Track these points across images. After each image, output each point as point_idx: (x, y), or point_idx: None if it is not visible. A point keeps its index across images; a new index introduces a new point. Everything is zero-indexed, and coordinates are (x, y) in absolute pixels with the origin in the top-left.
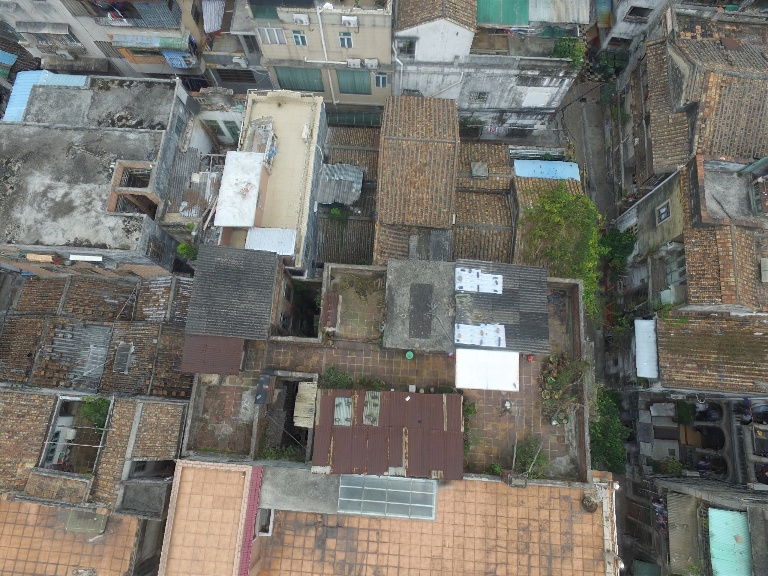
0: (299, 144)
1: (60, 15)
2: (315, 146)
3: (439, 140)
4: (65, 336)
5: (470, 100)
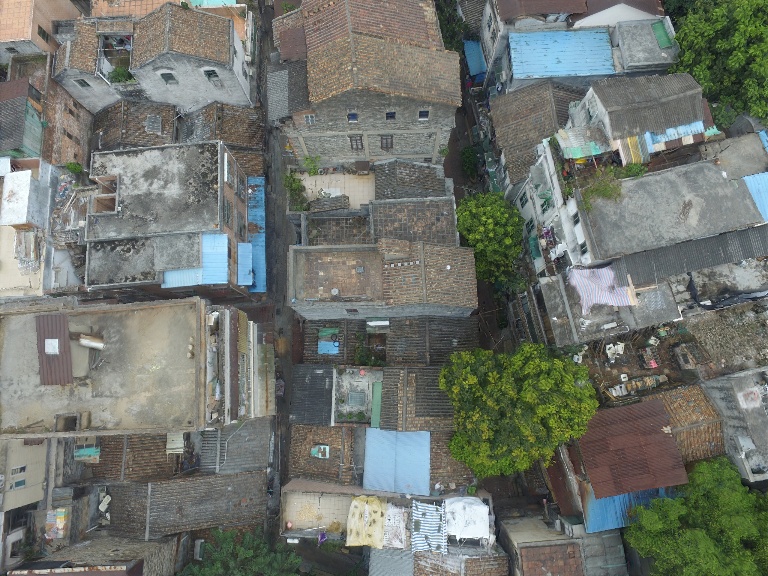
0: (5, 260)
1: None
2: None
3: None
4: None
5: None
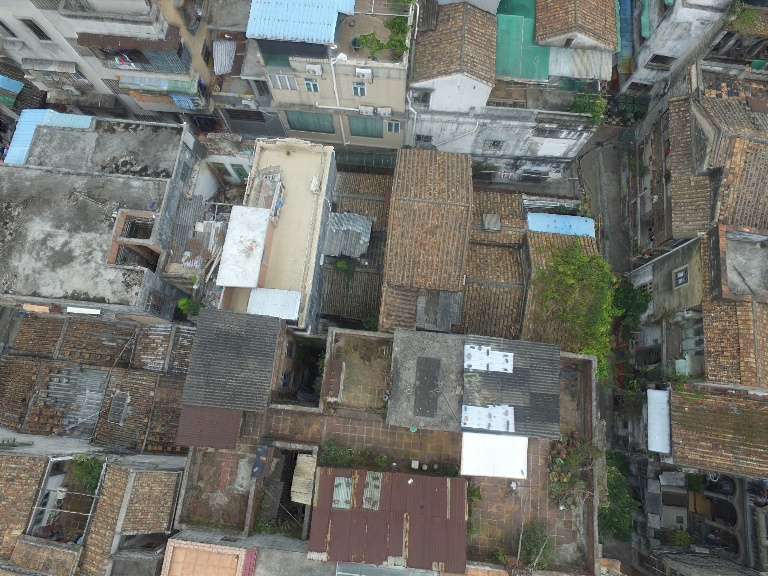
0: (307, 195)
1: (67, 54)
2: (323, 199)
3: (452, 203)
4: (61, 380)
5: (484, 147)
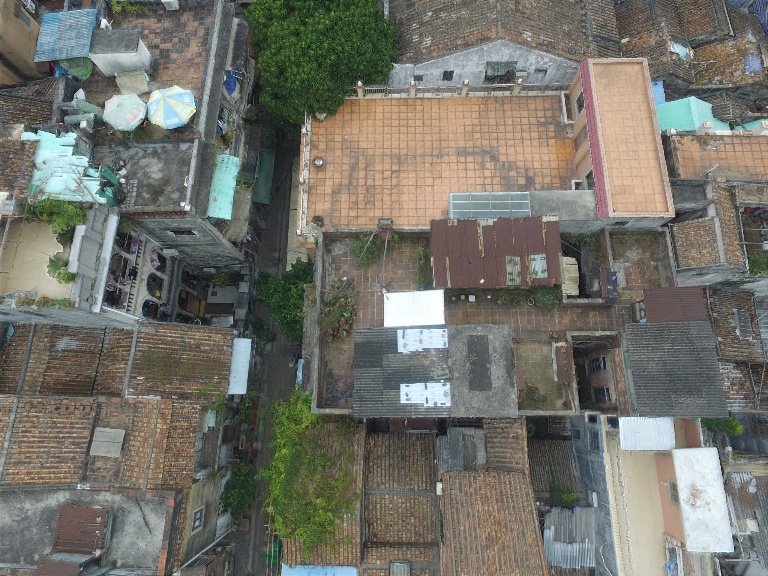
0: None
1: None
2: None
3: None
4: None
5: None
